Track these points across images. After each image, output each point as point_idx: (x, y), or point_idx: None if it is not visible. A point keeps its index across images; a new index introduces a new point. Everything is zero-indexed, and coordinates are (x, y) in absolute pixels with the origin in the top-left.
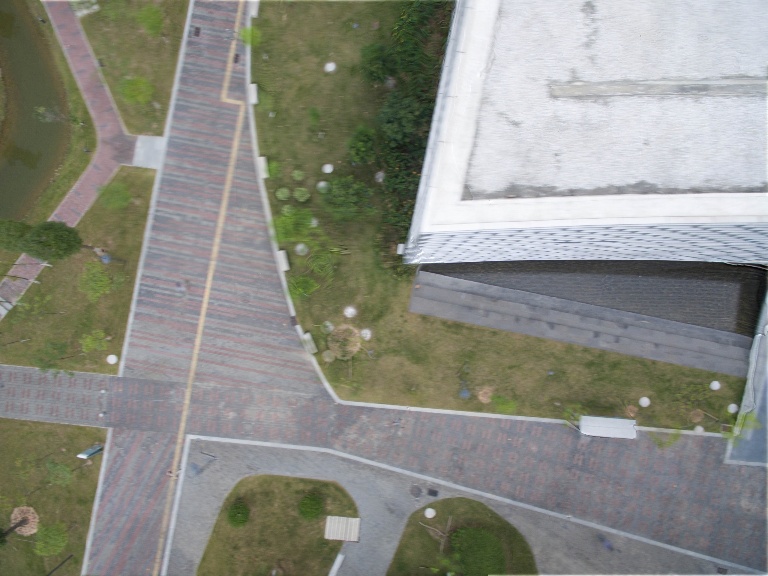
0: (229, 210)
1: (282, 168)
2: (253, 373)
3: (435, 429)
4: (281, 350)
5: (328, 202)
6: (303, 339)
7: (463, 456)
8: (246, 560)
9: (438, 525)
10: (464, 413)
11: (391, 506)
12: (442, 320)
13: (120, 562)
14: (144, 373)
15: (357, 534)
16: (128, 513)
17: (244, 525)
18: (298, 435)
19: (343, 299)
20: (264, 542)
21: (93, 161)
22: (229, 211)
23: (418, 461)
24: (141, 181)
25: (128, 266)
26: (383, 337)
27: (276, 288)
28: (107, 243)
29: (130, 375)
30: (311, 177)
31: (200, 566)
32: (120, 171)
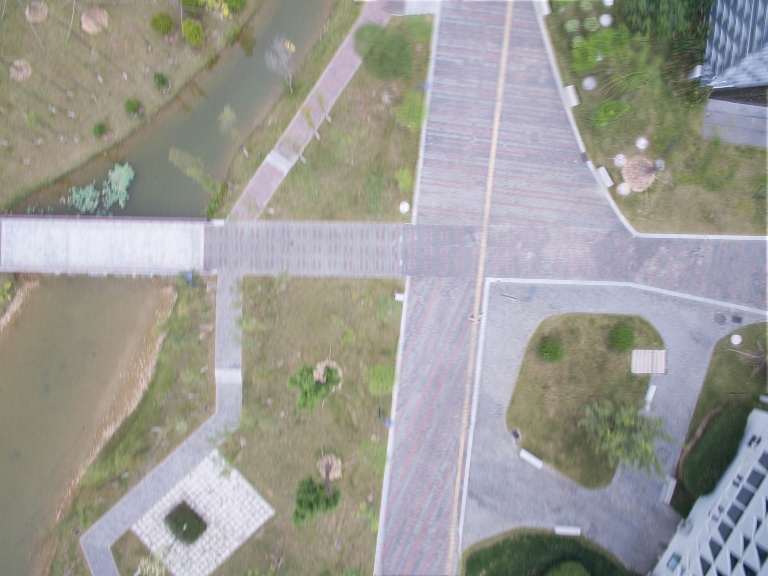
0: (510, 50)
1: (564, 3)
2: (548, 212)
3: (735, 256)
4: (574, 187)
5: (613, 34)
6: (598, 173)
7: (764, 281)
8: (557, 399)
9: (747, 350)
10: (762, 238)
11: (696, 336)
12: (735, 145)
13: (428, 411)
14: (438, 219)
15: (663, 366)
16: (432, 361)
17: (553, 363)
18: (598, 271)
19: (635, 131)
20: (574, 379)
21: (362, 13)
22: (510, 51)
23: (720, 289)
24: (418, 27)
25: (413, 112)
26: (677, 166)
27: (564, 125)
28: (391, 90)
29: (424, 222)
30: (594, 10)
31: (509, 409)
32: (390, 21)
